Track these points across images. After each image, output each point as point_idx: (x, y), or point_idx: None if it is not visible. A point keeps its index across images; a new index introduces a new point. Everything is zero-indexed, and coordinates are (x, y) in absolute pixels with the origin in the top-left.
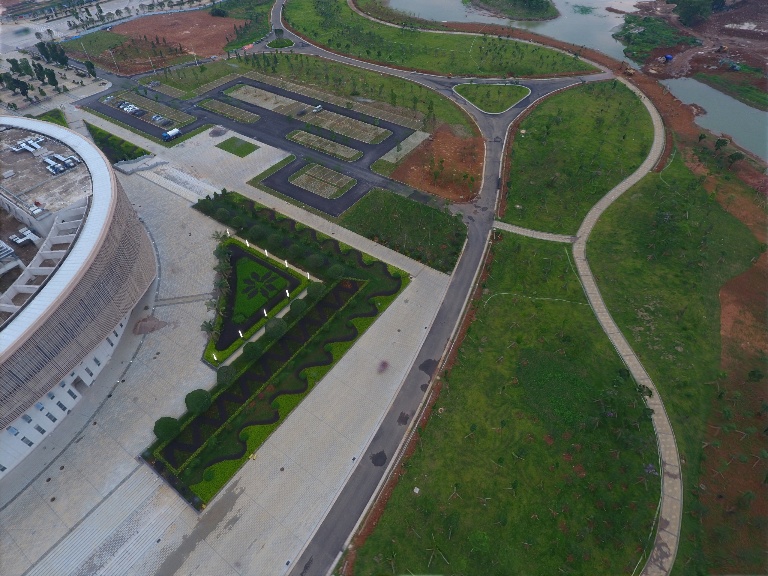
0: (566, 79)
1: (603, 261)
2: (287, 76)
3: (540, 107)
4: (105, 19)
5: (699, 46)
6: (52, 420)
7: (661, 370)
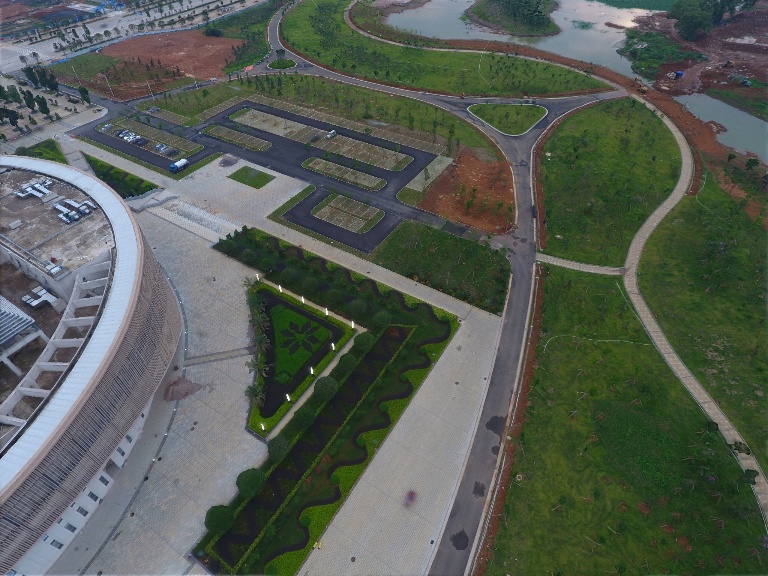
0: (581, 97)
1: (659, 295)
2: (294, 99)
3: (561, 128)
4: (93, 40)
5: (705, 61)
6: (83, 514)
7: (745, 418)
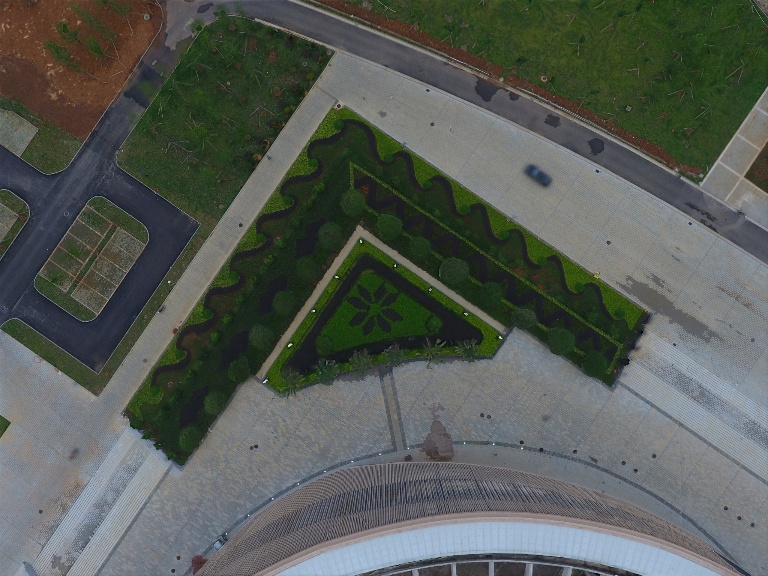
0: None
1: None
2: None
3: None
4: None
5: None
6: None
7: None
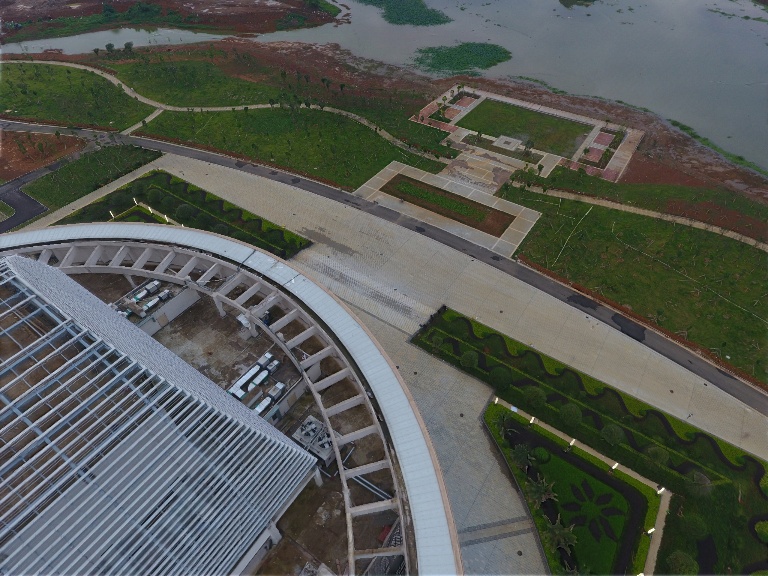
0: None
1: (188, 102)
2: None
3: None
4: None
5: None
6: None
7: None
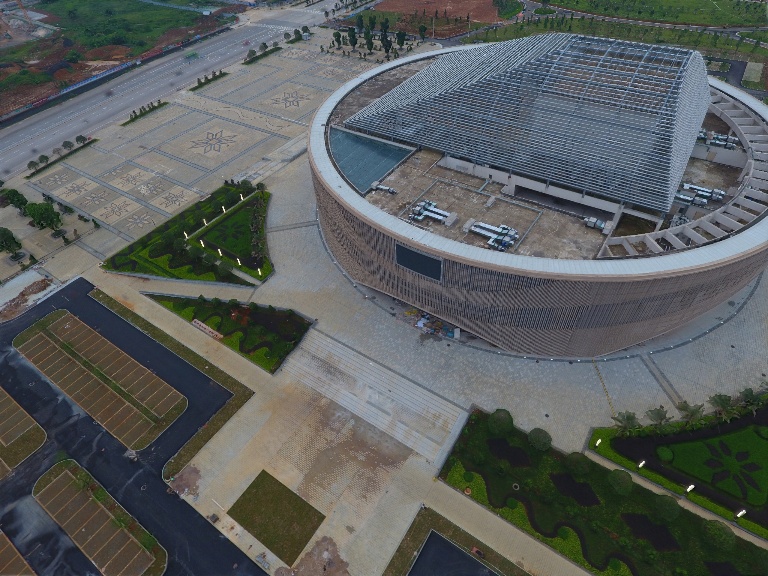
0: None
1: None
2: (584, 33)
3: None
4: (362, 1)
5: None
6: None
7: None
